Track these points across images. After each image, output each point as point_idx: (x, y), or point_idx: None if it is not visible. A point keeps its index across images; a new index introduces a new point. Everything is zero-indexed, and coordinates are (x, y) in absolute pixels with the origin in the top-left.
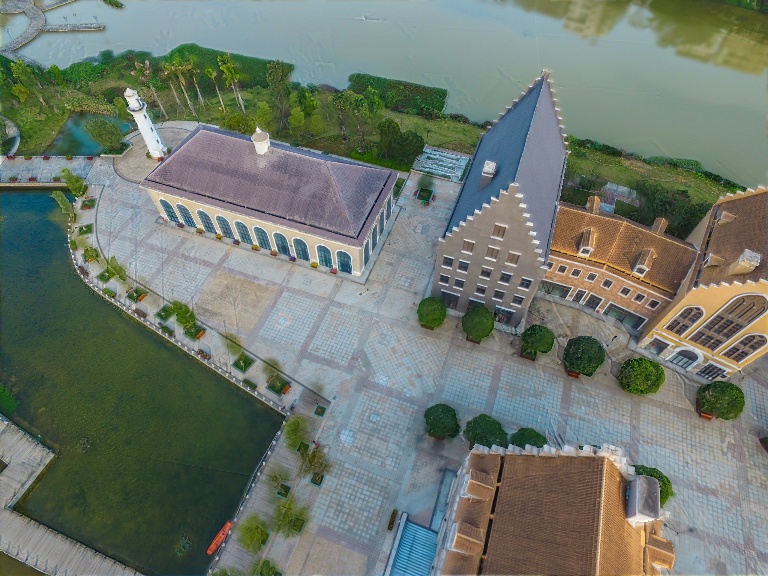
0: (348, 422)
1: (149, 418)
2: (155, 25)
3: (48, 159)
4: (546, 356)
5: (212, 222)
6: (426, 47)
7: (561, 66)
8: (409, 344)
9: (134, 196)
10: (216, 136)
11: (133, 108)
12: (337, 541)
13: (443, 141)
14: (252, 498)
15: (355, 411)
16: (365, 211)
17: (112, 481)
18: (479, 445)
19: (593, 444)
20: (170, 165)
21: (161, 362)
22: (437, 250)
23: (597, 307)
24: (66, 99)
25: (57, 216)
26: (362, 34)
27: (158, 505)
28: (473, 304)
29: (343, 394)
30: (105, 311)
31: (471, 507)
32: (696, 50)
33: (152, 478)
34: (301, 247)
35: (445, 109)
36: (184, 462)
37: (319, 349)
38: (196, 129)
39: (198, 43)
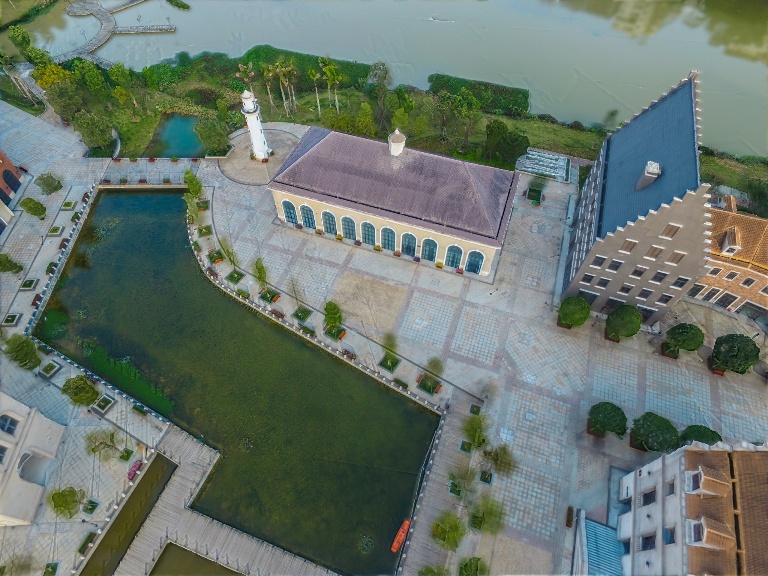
0: (505, 421)
1: (305, 418)
2: (225, 26)
3: (153, 161)
4: (687, 354)
5: (336, 223)
6: (499, 47)
7: (636, 66)
8: (549, 343)
9: (246, 197)
10: (348, 138)
11: (248, 110)
12: (519, 538)
13: (537, 141)
14: (426, 496)
15: (510, 410)
16: (499, 211)
17: (281, 480)
18: (698, 442)
19: (751, 441)
20: (299, 167)
21: (305, 362)
22: (590, 250)
23: (729, 305)
24: (155, 101)
25: (172, 218)
26: (433, 35)
27: (332, 504)
28: (611, 303)
29: (494, 393)
30: (239, 312)
31: (705, 503)
32: (767, 49)
33: (320, 477)
34: (429, 247)
35: (530, 109)
36: (349, 461)
37: (461, 348)
38: (315, 131)
39: (272, 44)
